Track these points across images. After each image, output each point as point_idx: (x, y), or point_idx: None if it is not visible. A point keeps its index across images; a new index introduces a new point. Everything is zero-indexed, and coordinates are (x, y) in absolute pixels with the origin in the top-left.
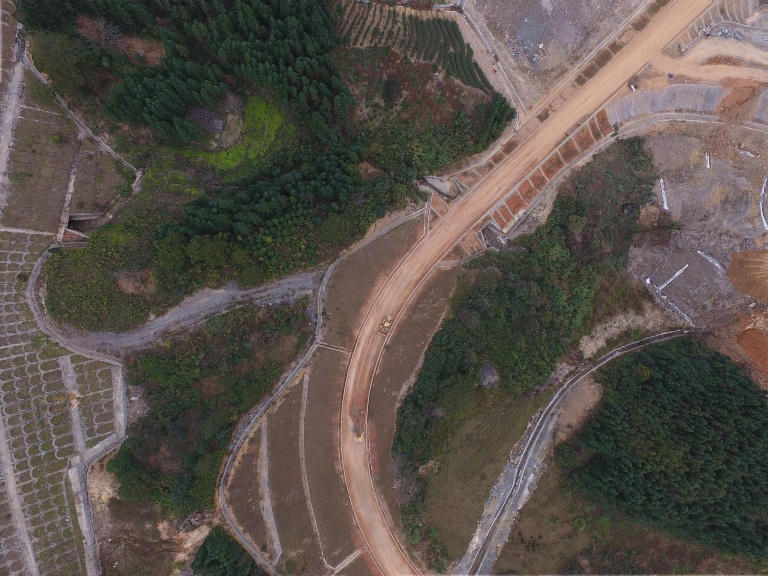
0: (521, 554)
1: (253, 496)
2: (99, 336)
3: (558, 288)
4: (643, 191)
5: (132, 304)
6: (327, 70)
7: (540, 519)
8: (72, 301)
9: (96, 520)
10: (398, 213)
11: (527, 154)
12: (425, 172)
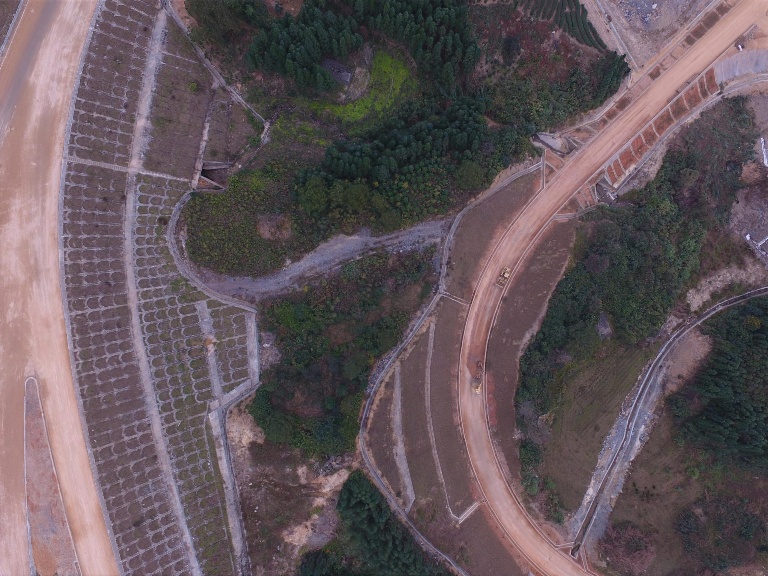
0: (636, 504)
1: (387, 441)
2: (236, 281)
3: (667, 242)
4: (746, 149)
5: (270, 248)
6: (462, 21)
7: (653, 469)
8: (214, 244)
9: (236, 464)
10: (518, 166)
11: (640, 110)
12: (542, 127)
